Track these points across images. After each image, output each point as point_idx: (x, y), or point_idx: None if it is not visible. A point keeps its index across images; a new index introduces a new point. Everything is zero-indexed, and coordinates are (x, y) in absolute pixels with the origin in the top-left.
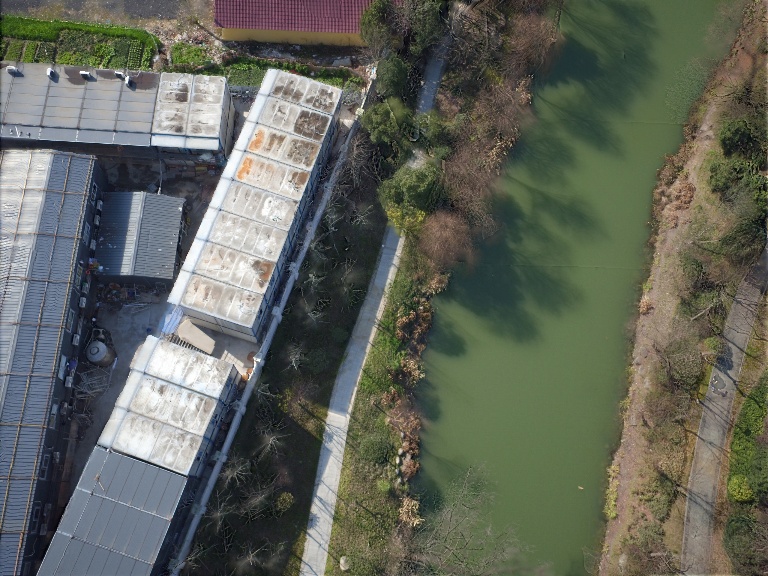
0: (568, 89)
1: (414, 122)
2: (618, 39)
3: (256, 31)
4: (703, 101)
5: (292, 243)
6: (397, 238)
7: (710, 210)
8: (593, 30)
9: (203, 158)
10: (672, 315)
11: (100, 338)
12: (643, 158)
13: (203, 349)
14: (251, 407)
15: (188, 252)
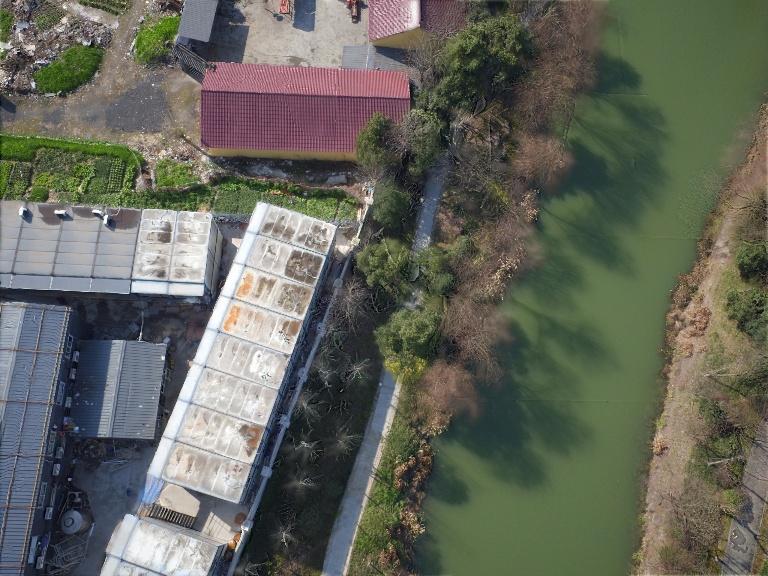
0: (576, 201)
1: (413, 244)
2: (628, 145)
3: (245, 150)
4: (718, 213)
5: (283, 393)
6: (395, 375)
7: (727, 339)
8: (602, 135)
9: (187, 301)
10: (688, 457)
11: (76, 502)
12: (655, 277)
13: (187, 513)
14: (239, 575)
15: (170, 416)
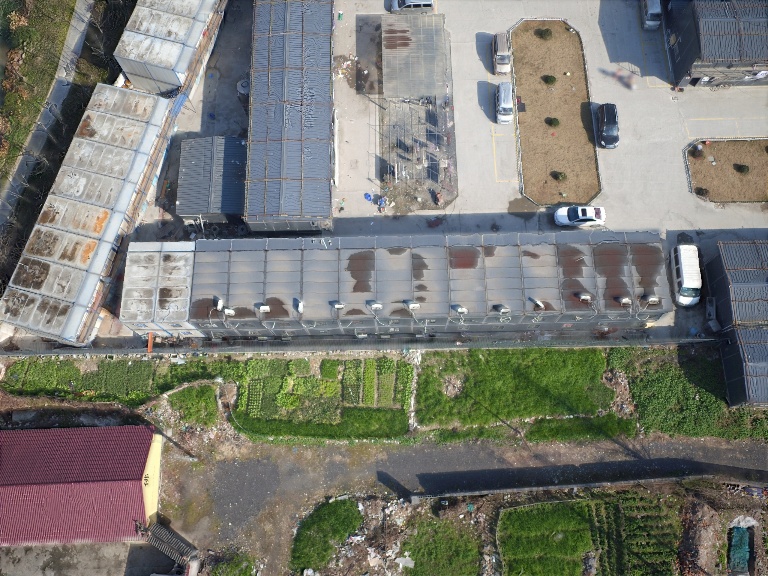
0: None
1: None
2: None
3: None
4: None
5: None
6: None
7: None
8: None
9: None
10: None
11: None
12: None
13: None
14: None
15: None
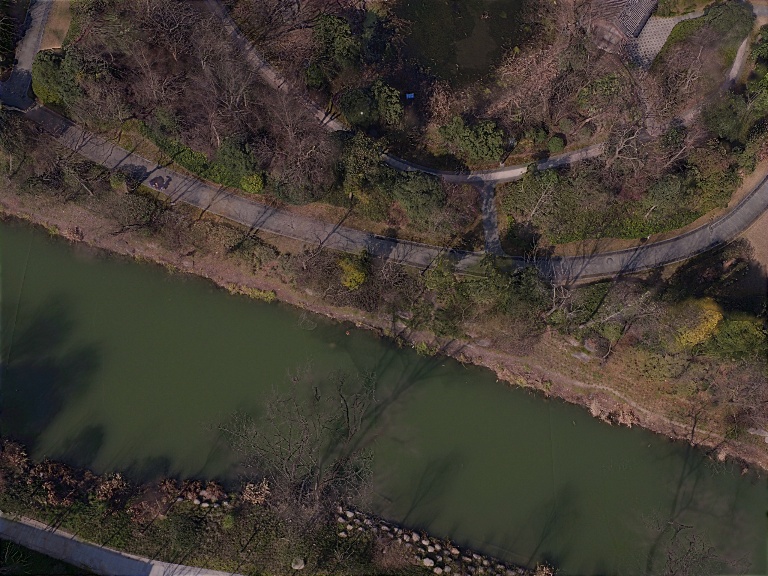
0: None
1: None
2: None
3: None
4: None
5: None
6: None
7: None
8: None
9: None
10: (86, 212)
11: None
12: None
13: None
14: None
15: None
